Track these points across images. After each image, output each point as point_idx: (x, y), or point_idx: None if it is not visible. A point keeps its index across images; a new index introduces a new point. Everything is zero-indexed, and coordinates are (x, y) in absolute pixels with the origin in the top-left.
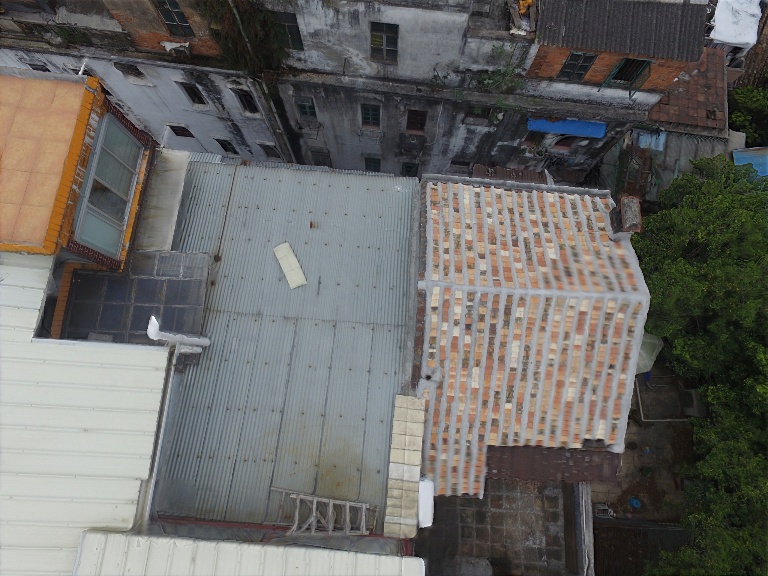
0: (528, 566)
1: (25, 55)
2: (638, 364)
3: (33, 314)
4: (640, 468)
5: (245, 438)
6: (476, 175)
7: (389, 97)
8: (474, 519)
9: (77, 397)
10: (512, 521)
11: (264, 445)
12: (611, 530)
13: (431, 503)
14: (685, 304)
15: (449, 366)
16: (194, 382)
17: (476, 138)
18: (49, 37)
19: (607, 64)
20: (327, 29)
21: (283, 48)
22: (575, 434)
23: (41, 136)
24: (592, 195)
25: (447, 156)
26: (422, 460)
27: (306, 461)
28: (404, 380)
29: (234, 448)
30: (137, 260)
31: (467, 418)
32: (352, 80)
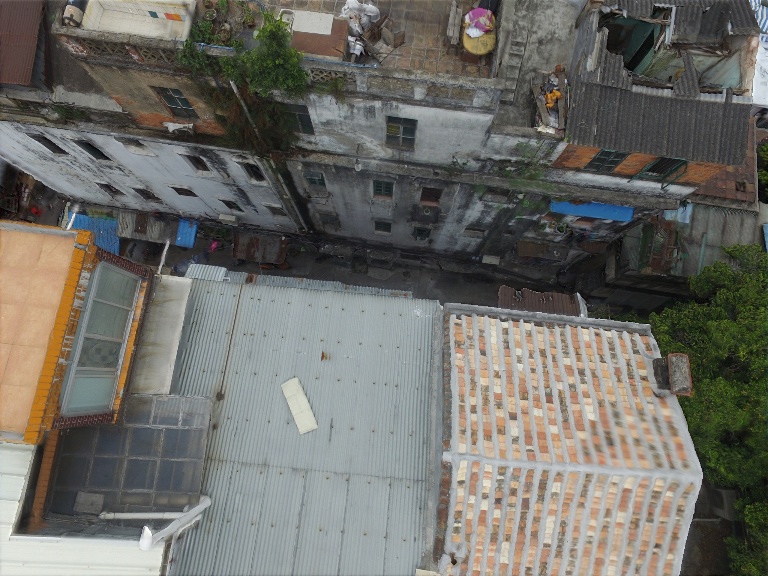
0: None
1: (21, 125)
2: None
3: (12, 506)
4: None
5: None
6: (502, 300)
7: (403, 176)
8: None
9: None
10: None
11: None
12: None
13: None
14: None
15: (476, 540)
16: (192, 551)
17: (493, 211)
18: (46, 113)
19: (640, 160)
20: (340, 120)
21: (293, 132)
22: None
23: (25, 300)
24: (630, 329)
25: (461, 224)
26: None
27: None
28: (425, 549)
29: None
30: (132, 406)
31: None
32: (365, 162)
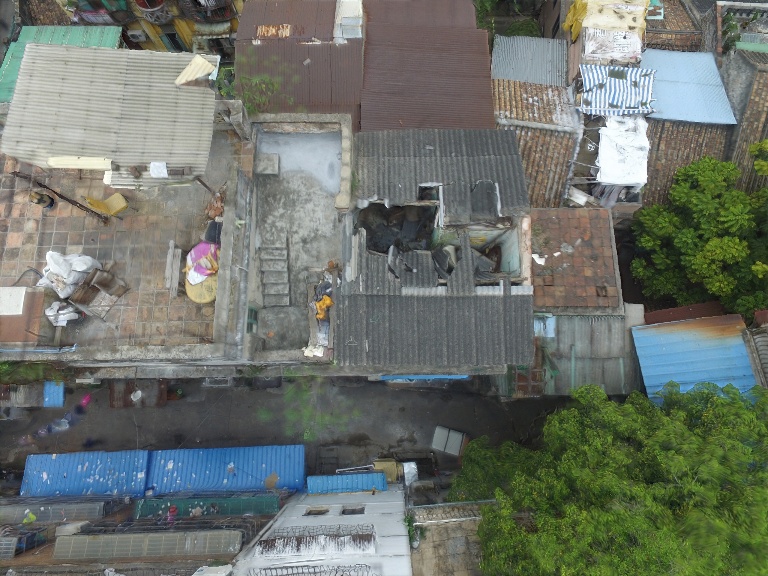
0: None
1: None
2: None
3: None
4: None
5: None
6: None
7: None
8: None
9: None
10: None
11: None
12: None
13: None
14: None
15: None
16: None
17: None
18: None
19: None
20: None
21: None
22: None
23: None
24: None
25: None
26: None
27: None
28: None
29: None
30: None
31: None
32: (160, 369)
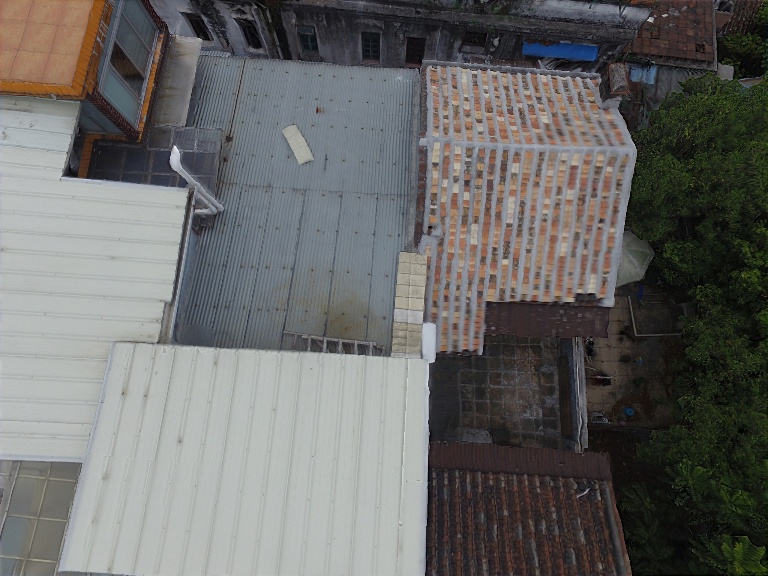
0: (526, 435)
1: None
2: (630, 272)
3: (61, 156)
4: (633, 380)
5: (258, 291)
6: None
7: (389, 23)
8: (474, 395)
9: (104, 229)
10: (510, 396)
11: (276, 297)
12: (606, 436)
13: (434, 342)
14: (674, 205)
15: (449, 223)
16: (210, 242)
17: None
18: None
19: None
20: None
21: None
22: (568, 288)
23: None
24: (583, 78)
25: None
26: (425, 318)
27: (316, 310)
28: (407, 241)
29: (248, 299)
30: (154, 134)
31: (467, 274)
32: (353, 3)
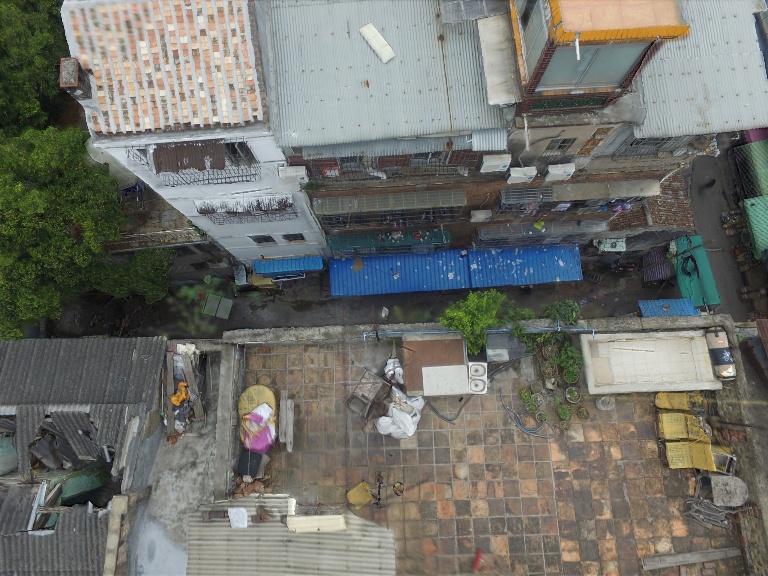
0: None
1: None
2: None
3: None
4: None
5: None
6: (221, 153)
7: None
8: None
9: None
10: None
11: None
12: None
13: None
14: None
15: None
16: None
17: None
18: None
19: None
20: None
21: None
22: None
23: None
24: (110, 139)
25: None
26: None
27: None
28: None
29: None
30: (502, 5)
31: None
32: None
